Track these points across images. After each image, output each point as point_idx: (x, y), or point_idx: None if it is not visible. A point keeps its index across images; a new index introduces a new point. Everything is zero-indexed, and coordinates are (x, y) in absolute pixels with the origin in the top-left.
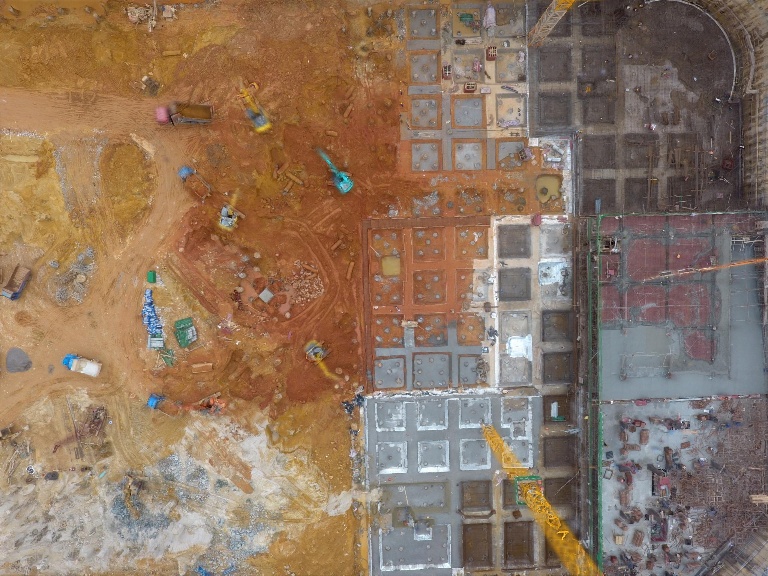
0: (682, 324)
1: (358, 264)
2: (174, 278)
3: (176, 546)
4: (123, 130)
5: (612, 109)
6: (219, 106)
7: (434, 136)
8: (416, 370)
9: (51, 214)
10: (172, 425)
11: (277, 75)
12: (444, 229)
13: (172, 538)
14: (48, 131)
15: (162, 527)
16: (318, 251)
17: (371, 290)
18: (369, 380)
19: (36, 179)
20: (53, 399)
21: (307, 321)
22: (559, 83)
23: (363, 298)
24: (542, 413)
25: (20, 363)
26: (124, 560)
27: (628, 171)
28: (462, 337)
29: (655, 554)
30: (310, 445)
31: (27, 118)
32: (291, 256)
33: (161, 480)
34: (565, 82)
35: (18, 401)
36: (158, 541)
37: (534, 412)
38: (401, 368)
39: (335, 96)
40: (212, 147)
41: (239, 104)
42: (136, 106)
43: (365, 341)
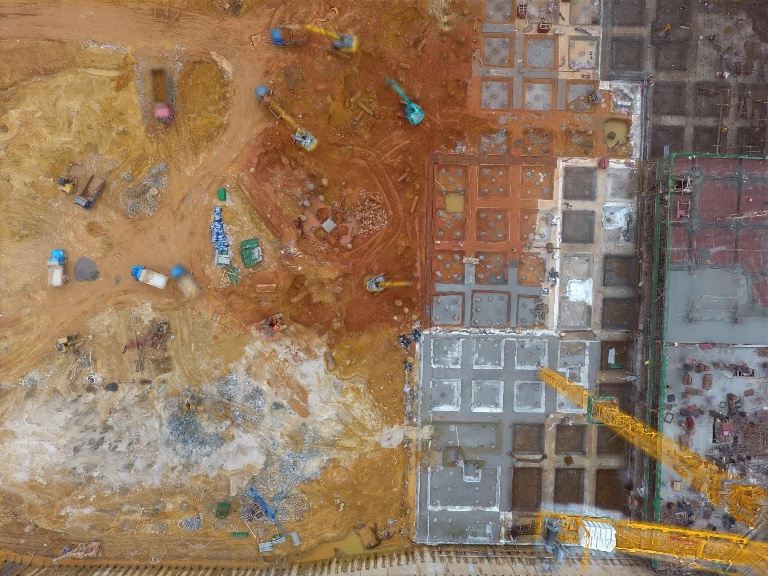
0: (751, 269)
1: (422, 198)
2: (243, 199)
3: (230, 465)
4: (204, 48)
5: (685, 56)
6: (299, 29)
7: (505, 74)
8: (474, 308)
9: (128, 127)
10: (233, 343)
11: (358, 1)
12: (510, 167)
13: (225, 458)
14: (131, 45)
15: (216, 446)
16: (384, 182)
17: (434, 225)
18: (427, 315)
19: (116, 92)
20: (117, 311)
21: (368, 253)
22: (633, 28)
23: (426, 232)
24: (599, 358)
25: (88, 272)
26: (178, 475)
27: (698, 119)
28: (522, 277)
29: (713, 503)
30: (366, 374)
31: (112, 31)
32: (357, 185)
33: (218, 399)
34: (639, 27)
35: (83, 310)
36: (211, 460)
37: (591, 357)
38: (459, 305)
39: (410, 30)
40: (290, 69)
41: (319, 28)
42: (218, 25)
43: (425, 275)
